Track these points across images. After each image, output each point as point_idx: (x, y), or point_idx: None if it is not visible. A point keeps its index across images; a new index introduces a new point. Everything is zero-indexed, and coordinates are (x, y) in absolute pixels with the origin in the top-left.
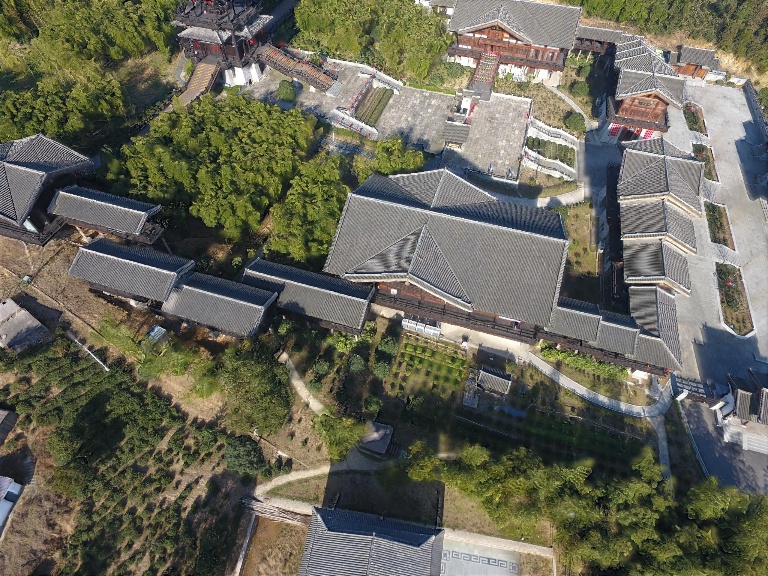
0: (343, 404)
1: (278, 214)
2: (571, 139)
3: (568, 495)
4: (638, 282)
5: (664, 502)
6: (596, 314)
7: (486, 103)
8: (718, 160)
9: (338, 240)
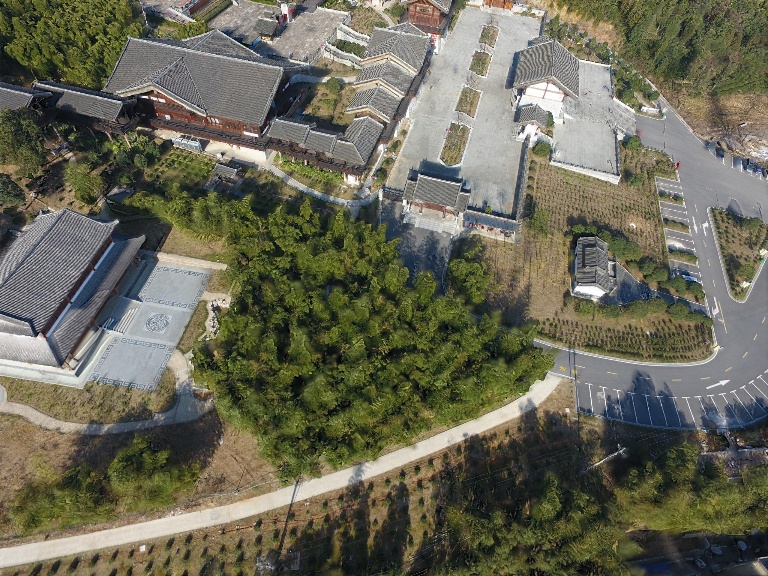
0: (107, 183)
1: (78, 56)
2: None
3: (238, 218)
4: (353, 112)
5: (310, 227)
6: (306, 125)
7: (310, 14)
8: (494, 63)
9: (116, 70)
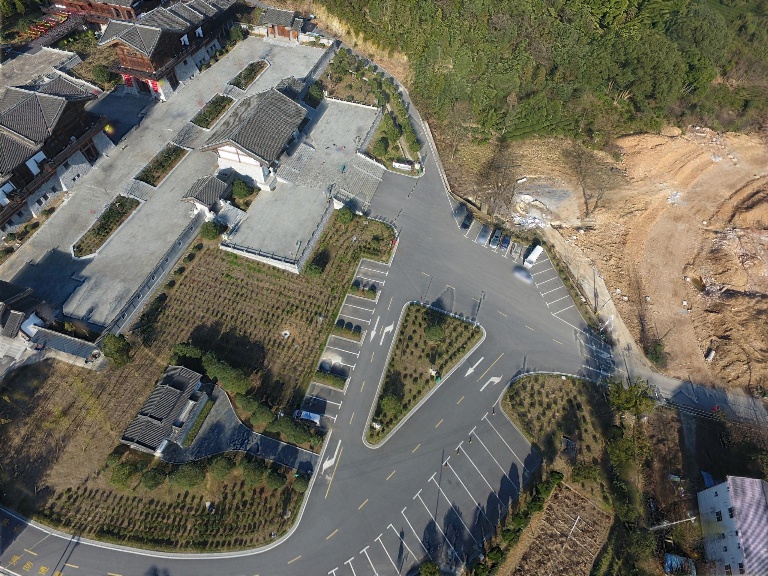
0: None
1: None
2: (95, 90)
3: None
4: None
5: None
6: None
7: (29, 56)
8: None
9: None
